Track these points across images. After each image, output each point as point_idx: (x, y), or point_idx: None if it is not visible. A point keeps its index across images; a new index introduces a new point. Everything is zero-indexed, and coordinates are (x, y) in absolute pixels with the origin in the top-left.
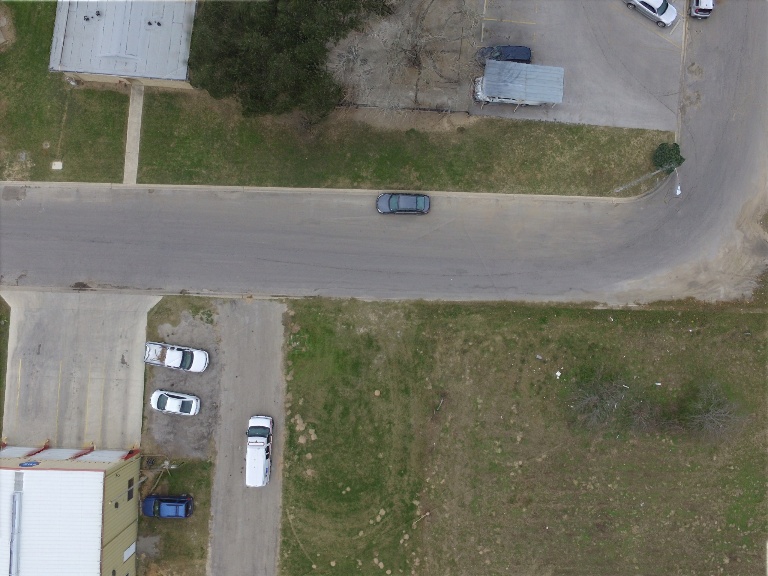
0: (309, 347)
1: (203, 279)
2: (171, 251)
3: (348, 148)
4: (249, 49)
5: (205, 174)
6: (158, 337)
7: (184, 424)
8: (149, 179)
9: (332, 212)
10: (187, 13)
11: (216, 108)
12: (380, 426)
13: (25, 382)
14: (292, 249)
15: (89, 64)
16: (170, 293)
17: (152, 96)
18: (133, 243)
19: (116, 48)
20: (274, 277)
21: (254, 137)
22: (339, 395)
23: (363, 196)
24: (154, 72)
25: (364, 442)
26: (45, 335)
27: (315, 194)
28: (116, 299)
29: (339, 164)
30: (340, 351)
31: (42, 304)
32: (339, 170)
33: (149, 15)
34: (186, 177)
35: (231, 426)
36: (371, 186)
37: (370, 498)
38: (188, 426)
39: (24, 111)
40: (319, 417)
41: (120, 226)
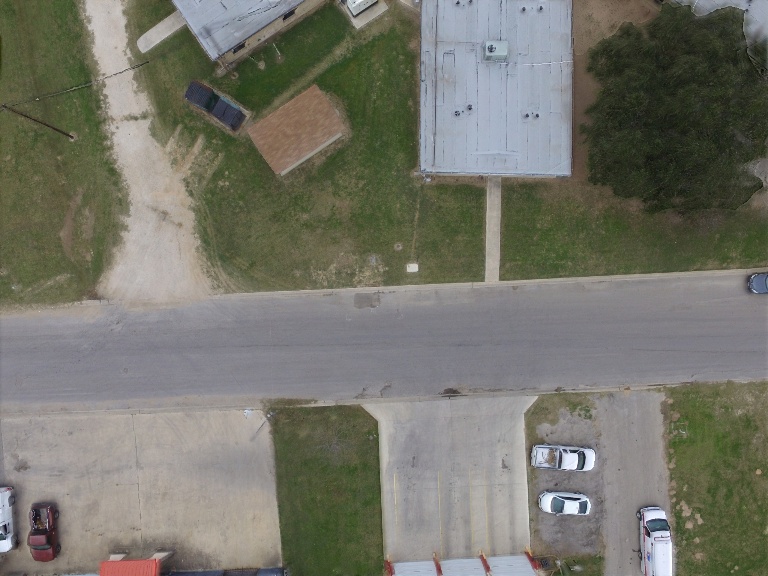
0: (690, 433)
1: (578, 375)
2: (543, 349)
3: (717, 229)
4: (693, 152)
5: (571, 266)
6: (537, 438)
7: (570, 522)
8: (513, 275)
9: (702, 295)
10: (565, 101)
11: (579, 196)
12: (763, 504)
13: (402, 497)
14: (667, 336)
15: (465, 163)
16: (545, 392)
17: (511, 187)
18: (502, 344)
19: (497, 145)
20: (650, 366)
21: (621, 224)
22: (721, 478)
23: (732, 276)
24: (537, 168)
25: (749, 521)
26: (418, 447)
27: (684, 278)
28: (489, 403)
29: (708, 246)
30: (720, 434)
31: (411, 415)
32: (709, 252)
33: (525, 106)
34: (552, 270)
35: (617, 519)
36: (740, 266)
37: (757, 574)
38: (574, 524)
39: (370, 211)
40: (703, 501)
41: (487, 327)
